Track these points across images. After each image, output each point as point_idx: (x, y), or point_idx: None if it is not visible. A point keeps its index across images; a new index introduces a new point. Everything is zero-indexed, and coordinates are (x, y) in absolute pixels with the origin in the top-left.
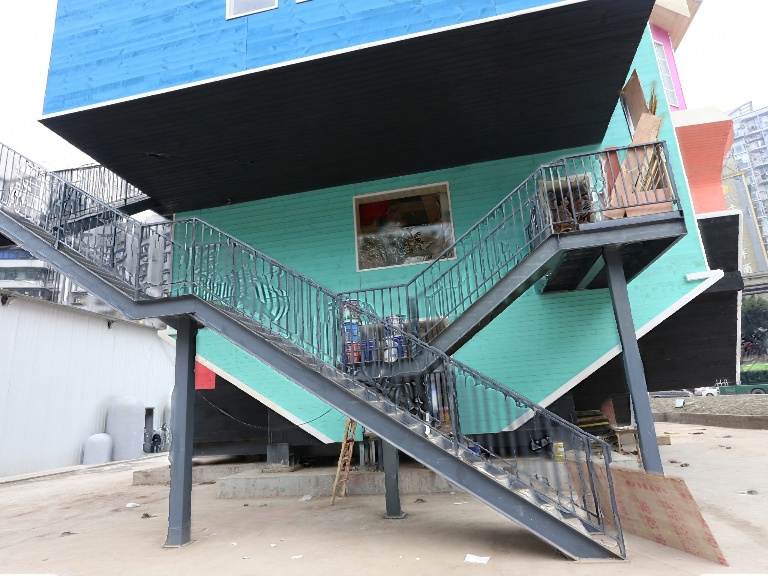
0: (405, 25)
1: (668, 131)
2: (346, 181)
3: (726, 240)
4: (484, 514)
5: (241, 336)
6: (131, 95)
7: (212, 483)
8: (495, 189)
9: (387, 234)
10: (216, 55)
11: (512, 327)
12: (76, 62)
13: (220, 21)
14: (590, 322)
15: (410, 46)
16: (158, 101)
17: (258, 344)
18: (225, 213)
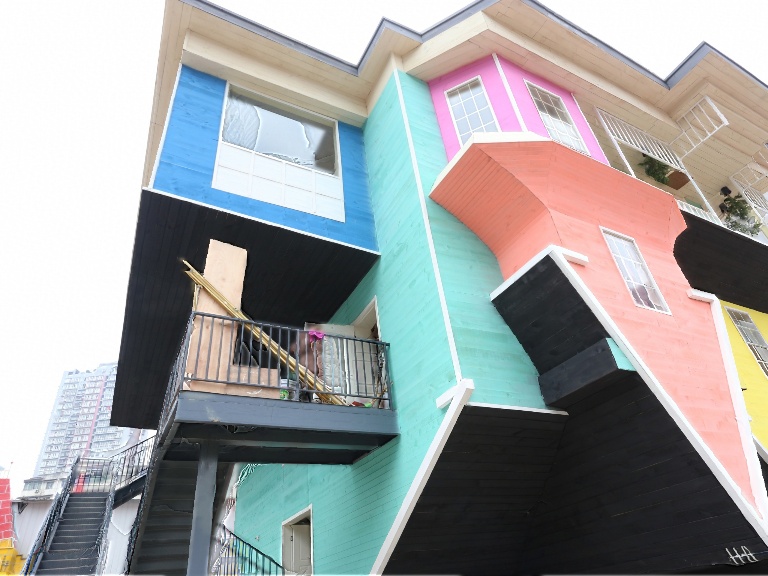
0: None
1: (417, 207)
2: None
3: (560, 298)
4: None
5: None
6: None
7: None
8: None
9: None
10: None
11: (339, 512)
12: None
13: None
14: (379, 495)
15: (134, 313)
16: (120, 397)
17: None
18: None
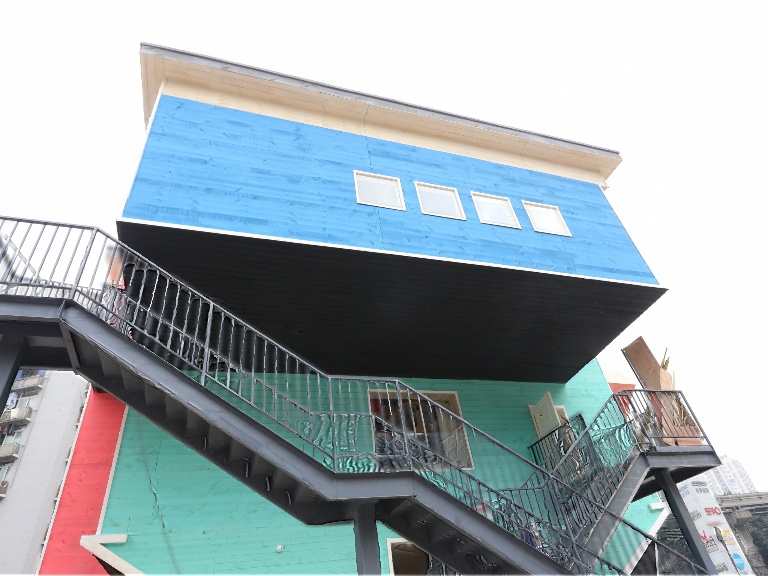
0: (516, 260)
1: (605, 384)
2: (363, 372)
3: None
4: None
5: (481, 531)
6: (257, 233)
7: None
8: (497, 406)
9: (388, 434)
10: (351, 228)
11: None
12: (177, 180)
13: (351, 202)
14: None
15: (521, 276)
16: (282, 248)
17: (503, 543)
18: None
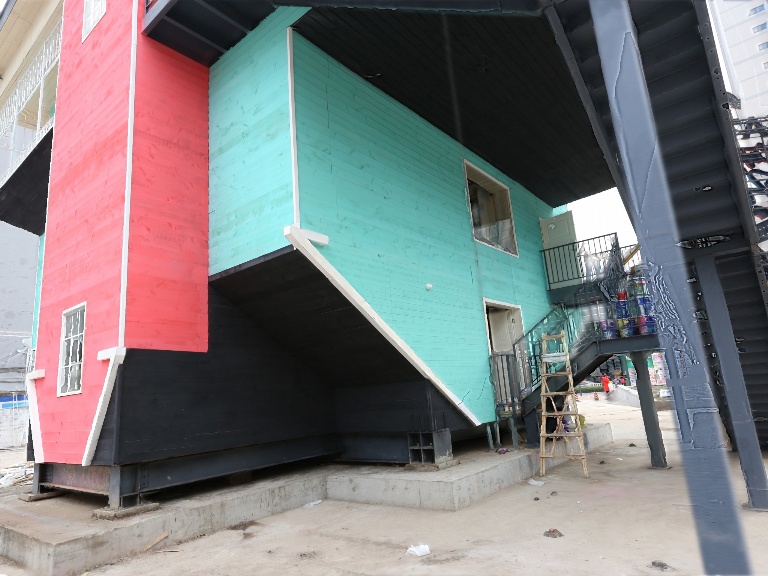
0: None
1: None
2: (466, 140)
3: None
4: (669, 457)
5: None
6: None
7: (252, 523)
8: None
9: None
10: None
11: None
12: None
13: None
14: None
15: None
16: None
17: None
18: (359, 86)
